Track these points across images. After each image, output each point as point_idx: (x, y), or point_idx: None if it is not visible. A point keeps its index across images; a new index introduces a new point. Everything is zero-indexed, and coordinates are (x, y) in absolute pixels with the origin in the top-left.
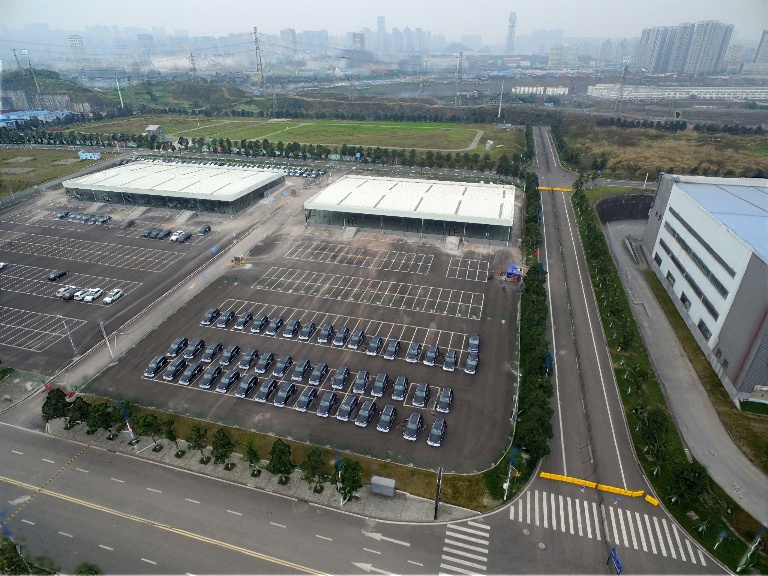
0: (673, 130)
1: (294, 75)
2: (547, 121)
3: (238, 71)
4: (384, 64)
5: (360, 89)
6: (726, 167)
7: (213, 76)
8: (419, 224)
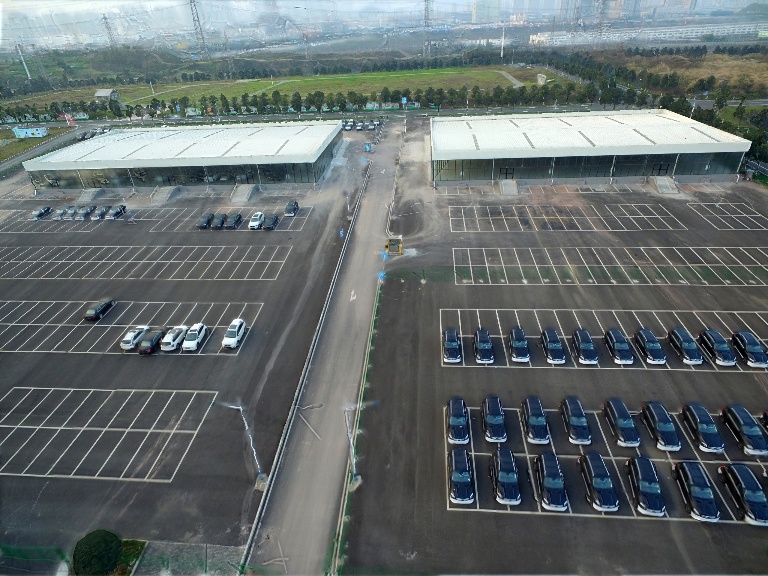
0: (693, 57)
1: (237, 33)
2: (554, 59)
3: (169, 32)
4: (342, 14)
5: (315, 46)
6: None
7: (136, 41)
8: (609, 164)
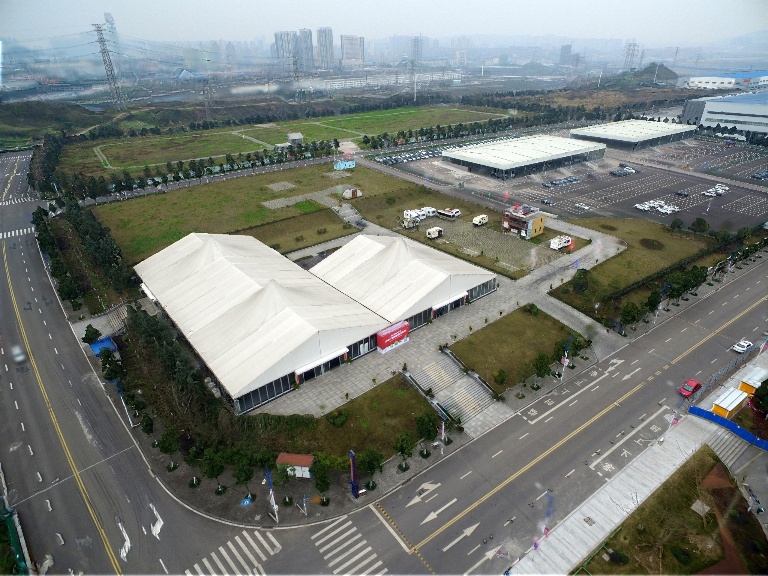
0: None
1: None
2: None
3: (66, 81)
4: (234, 66)
5: None
6: (612, 105)
7: None
8: None
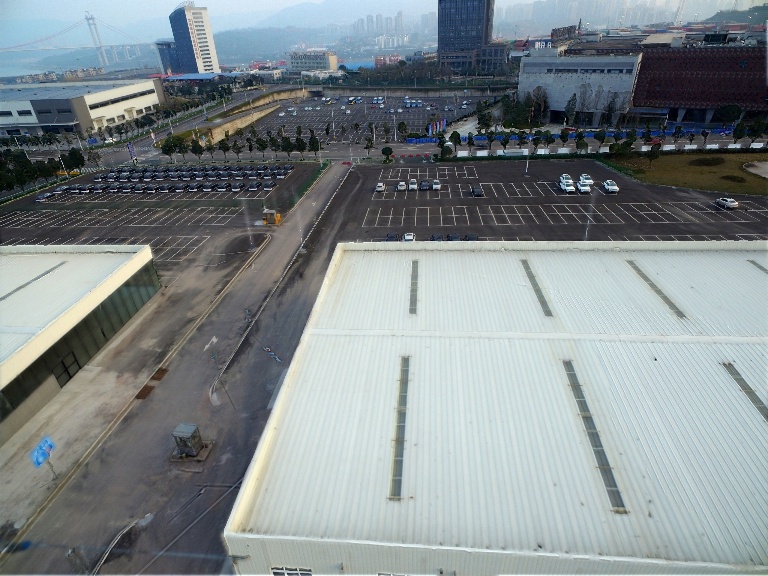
0: None
1: None
2: None
3: None
4: None
5: None
6: None
7: None
8: None
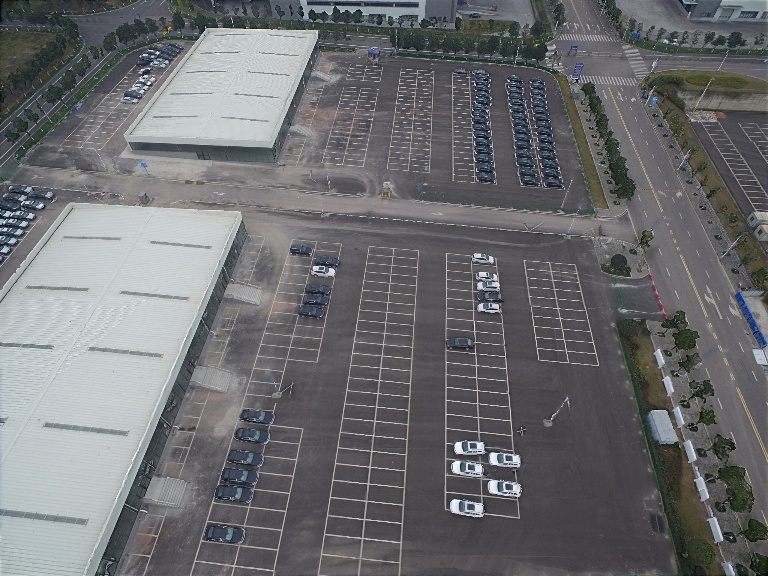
0: None
1: None
2: None
3: None
4: None
5: None
6: None
7: None
8: None
